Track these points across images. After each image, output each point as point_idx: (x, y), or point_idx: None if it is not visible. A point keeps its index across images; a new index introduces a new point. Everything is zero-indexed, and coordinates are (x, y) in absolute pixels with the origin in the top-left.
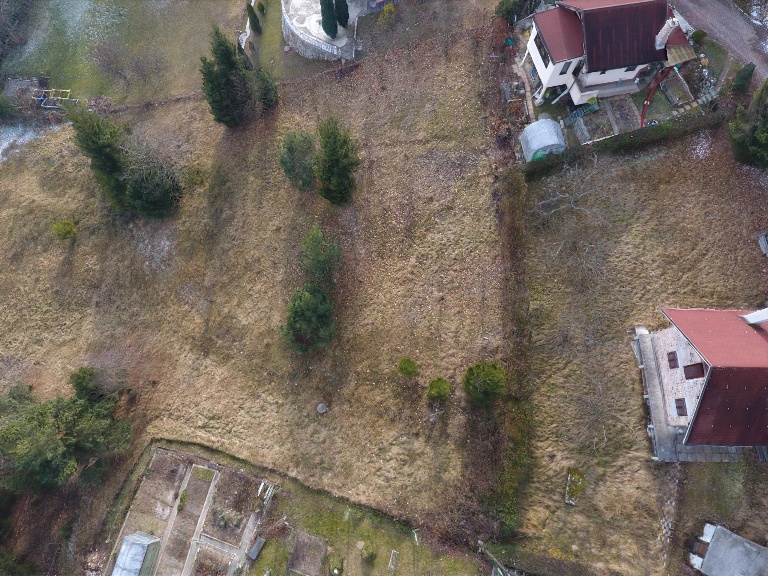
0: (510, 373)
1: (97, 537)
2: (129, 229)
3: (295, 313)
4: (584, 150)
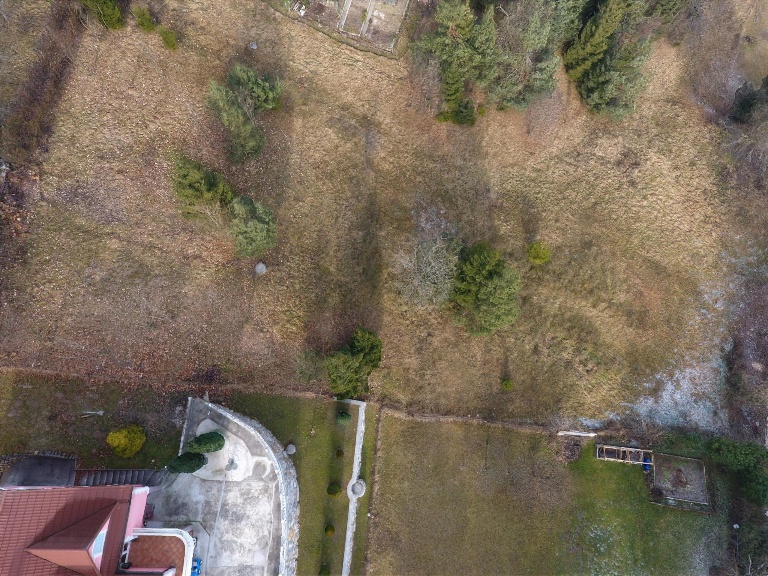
0: (77, 3)
1: (427, 11)
2: None
3: None
4: None
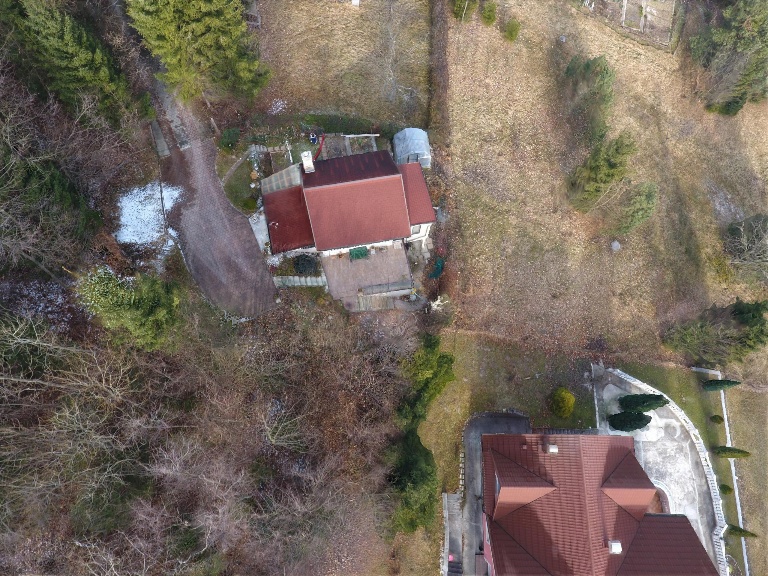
0: None
1: (687, 7)
2: None
3: None
4: (381, 124)
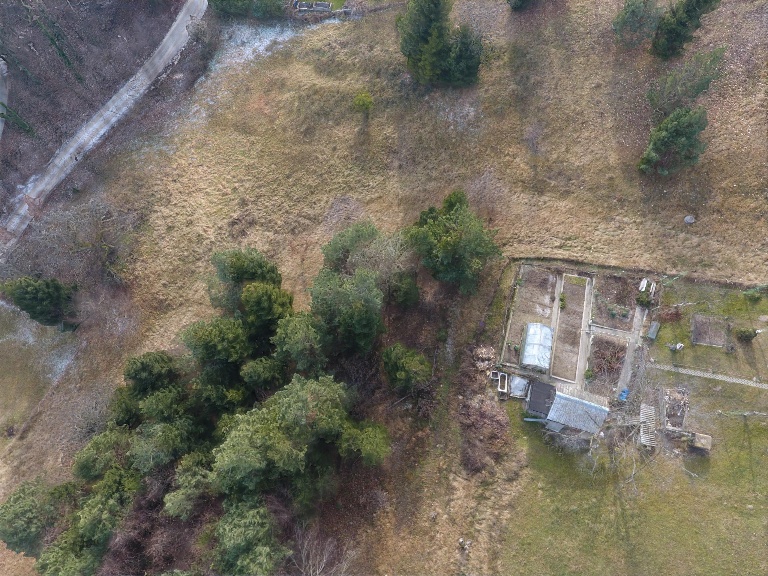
0: None
1: (479, 336)
2: (425, 101)
3: (671, 133)
4: None
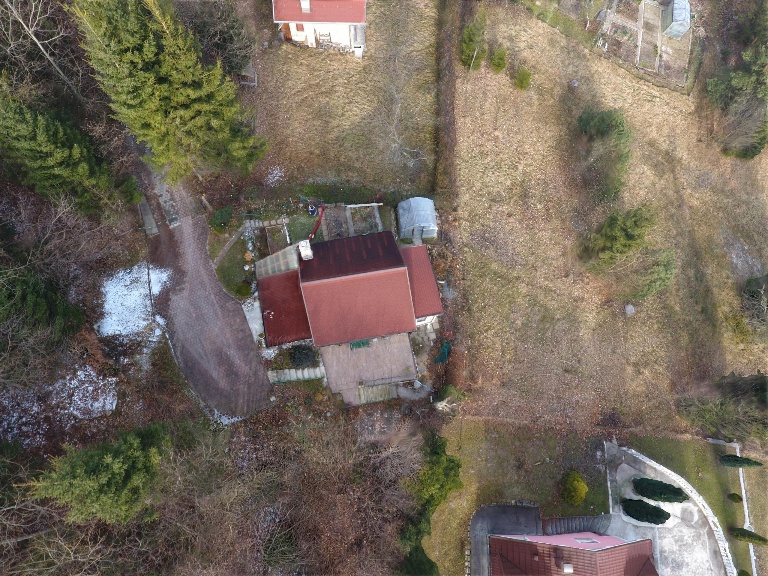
0: None
1: (704, 45)
2: None
3: None
4: (385, 193)
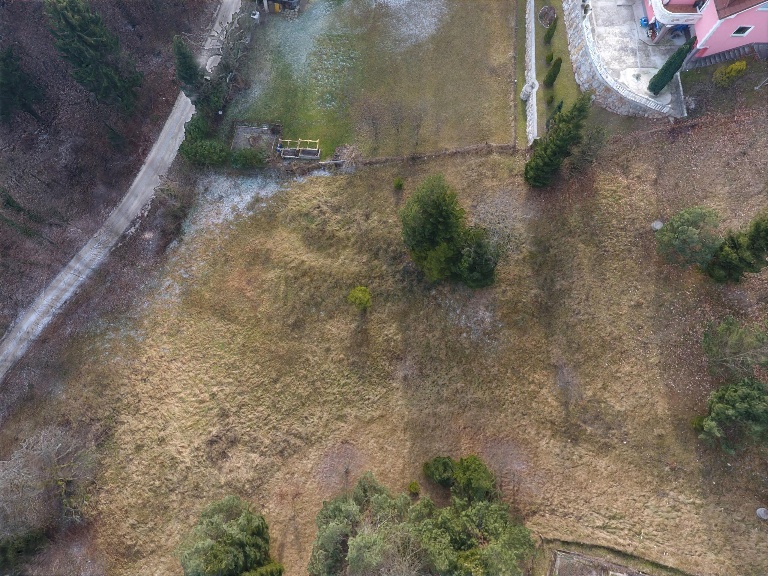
0: None
1: None
2: (432, 296)
3: (739, 412)
4: None
